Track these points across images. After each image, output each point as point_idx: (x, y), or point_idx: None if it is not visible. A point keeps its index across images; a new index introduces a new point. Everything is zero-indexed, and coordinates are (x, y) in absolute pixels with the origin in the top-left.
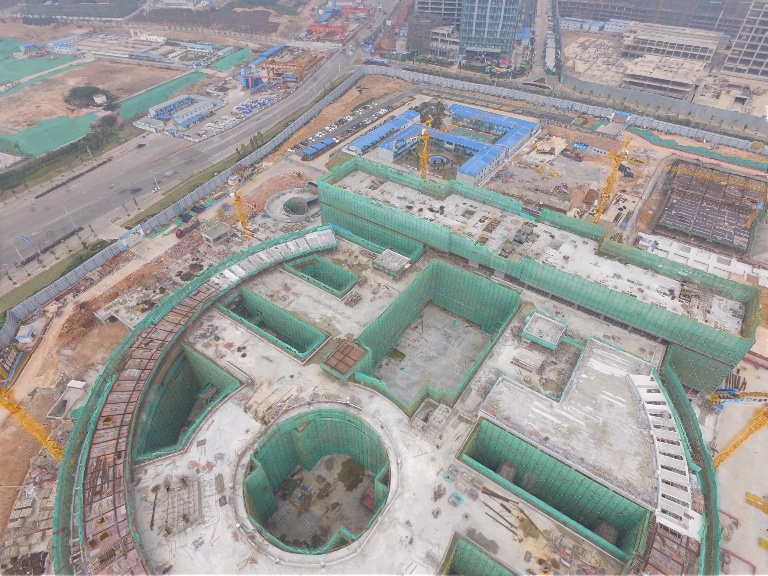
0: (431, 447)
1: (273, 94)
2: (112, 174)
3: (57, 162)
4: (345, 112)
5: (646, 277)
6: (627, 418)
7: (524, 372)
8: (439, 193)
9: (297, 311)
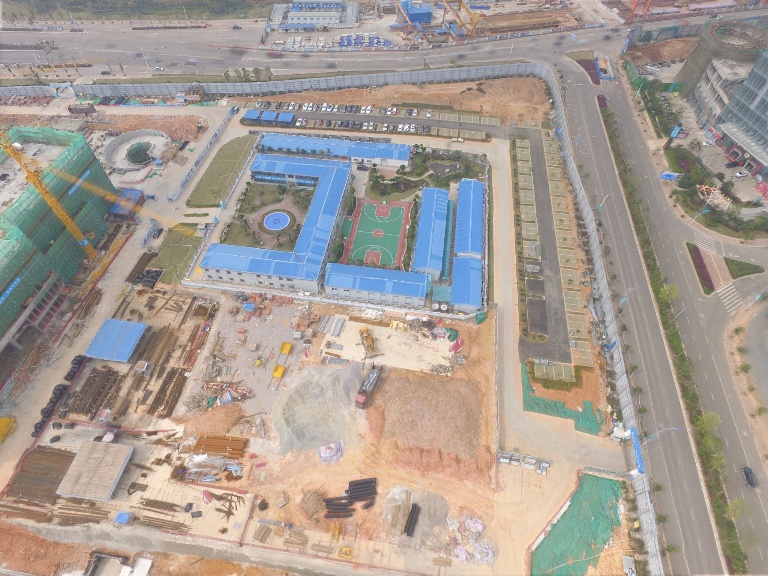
0: None
1: (406, 40)
2: (181, 39)
3: (189, 10)
4: (385, 101)
5: None
6: None
7: None
8: None
9: None
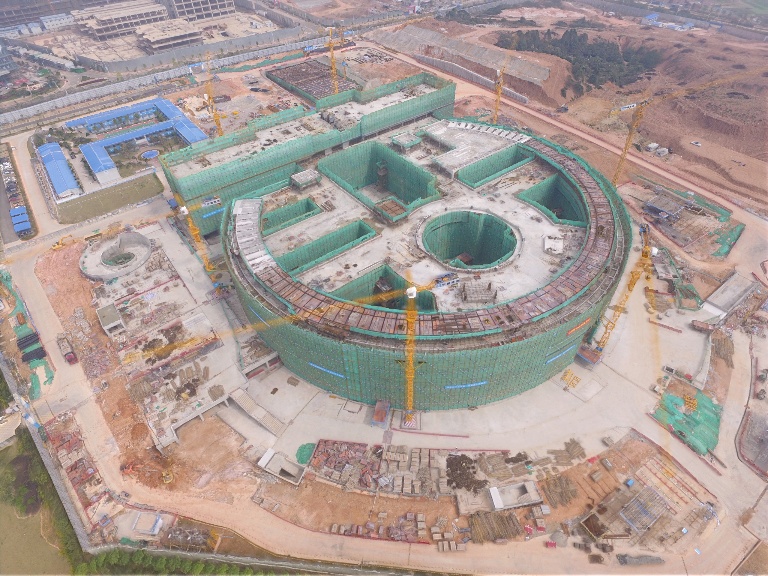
0: (464, 197)
1: None
2: None
3: None
4: None
5: (391, 98)
6: (471, 135)
7: (427, 158)
8: (253, 135)
9: (322, 235)
